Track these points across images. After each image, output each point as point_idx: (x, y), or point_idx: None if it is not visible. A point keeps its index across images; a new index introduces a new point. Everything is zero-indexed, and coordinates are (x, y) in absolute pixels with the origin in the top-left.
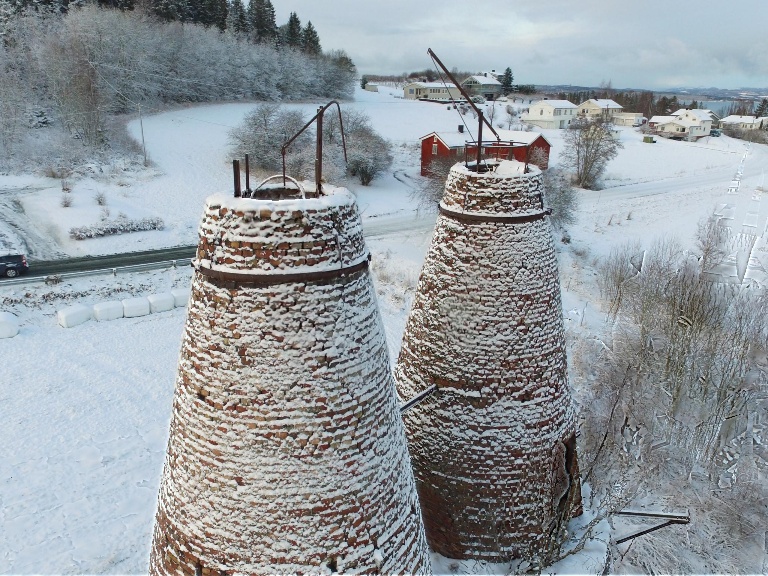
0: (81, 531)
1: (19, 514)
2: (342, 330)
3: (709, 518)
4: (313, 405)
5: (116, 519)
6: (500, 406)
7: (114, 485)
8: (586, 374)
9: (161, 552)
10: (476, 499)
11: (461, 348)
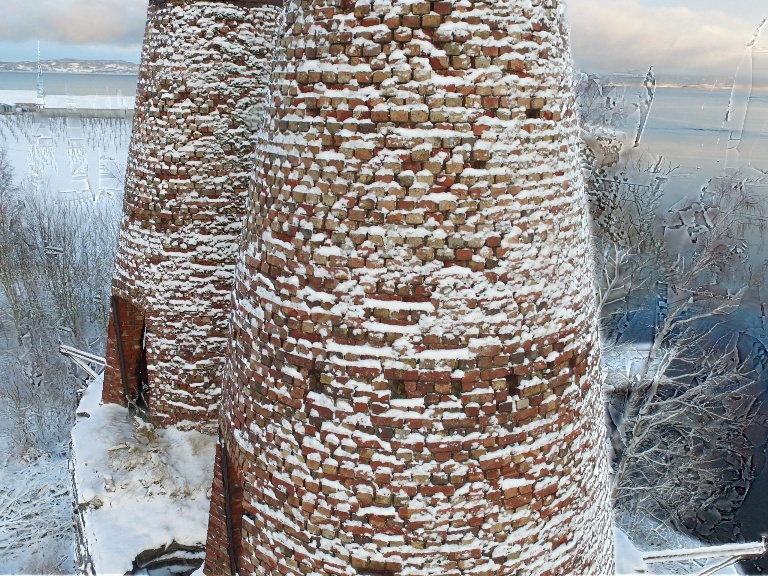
0: None
1: None
2: None
3: None
4: None
5: None
6: None
7: None
8: None
9: (498, 416)
10: None
11: None
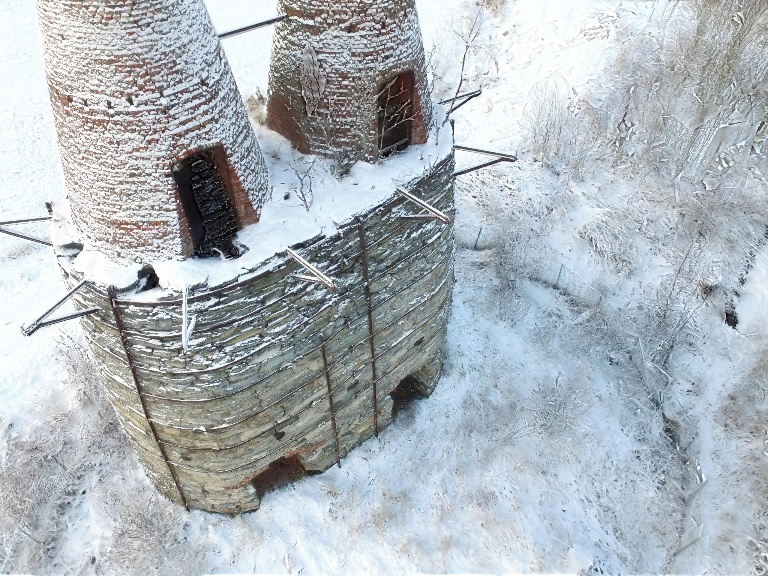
0: None
1: None
2: None
3: (676, 213)
4: None
5: None
6: (330, 34)
7: None
8: (623, 72)
9: None
10: None
11: None
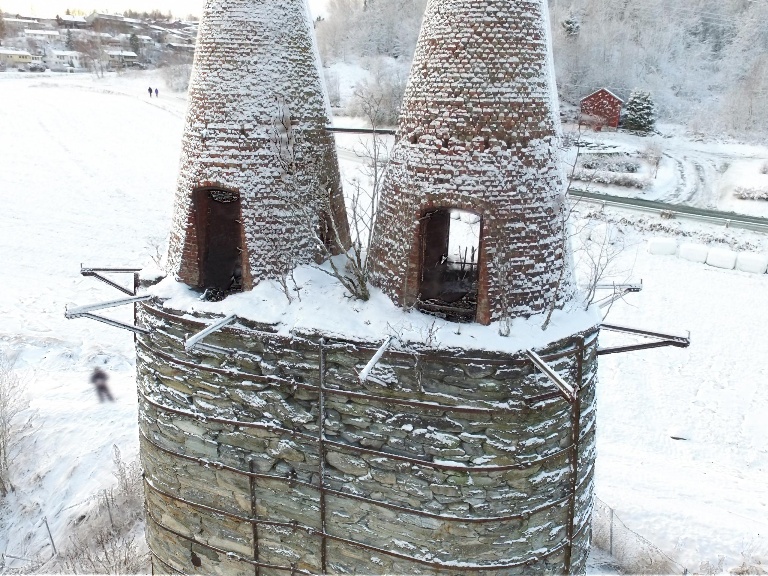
0: None
1: None
2: None
3: None
4: None
5: None
6: None
7: None
8: None
9: None
10: None
11: None
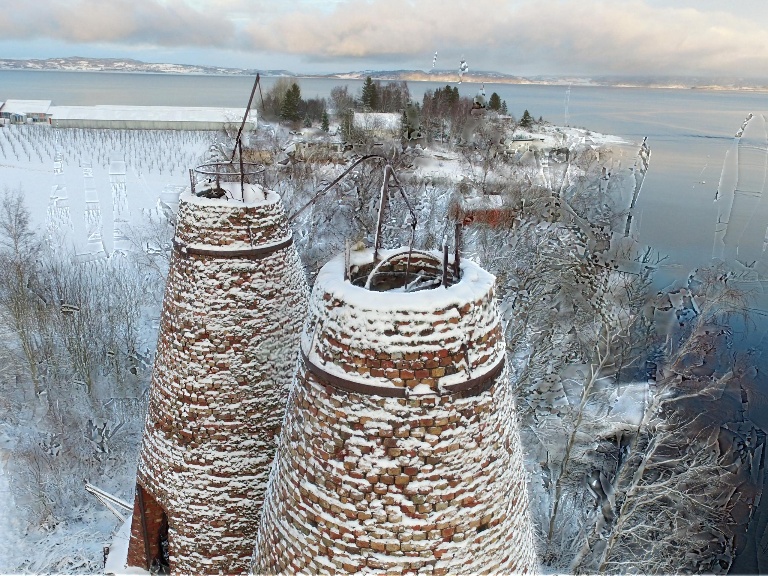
0: None
1: None
2: None
3: None
4: None
5: None
6: None
7: None
8: None
9: None
10: None
11: None
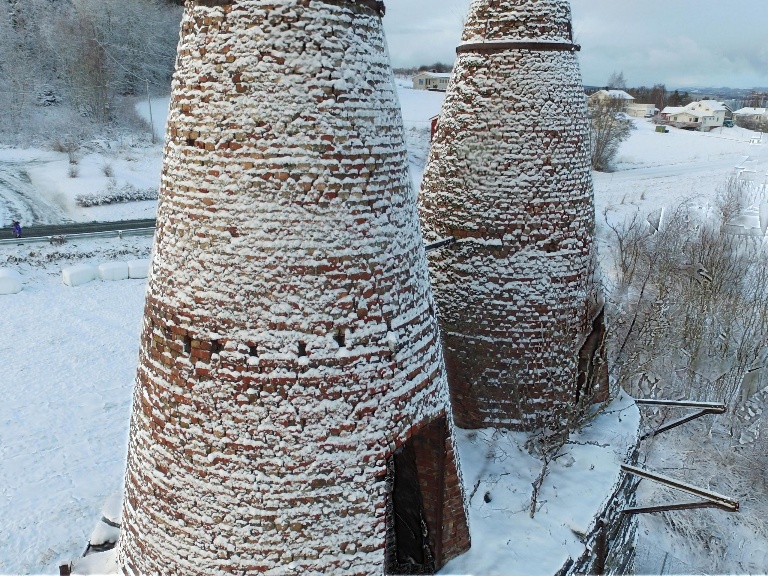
0: (81, 471)
1: (18, 453)
2: (352, 63)
3: (731, 472)
4: (318, 142)
5: (117, 461)
6: (523, 256)
7: (116, 429)
8: None
9: (147, 342)
10: (496, 360)
11: (481, 192)
